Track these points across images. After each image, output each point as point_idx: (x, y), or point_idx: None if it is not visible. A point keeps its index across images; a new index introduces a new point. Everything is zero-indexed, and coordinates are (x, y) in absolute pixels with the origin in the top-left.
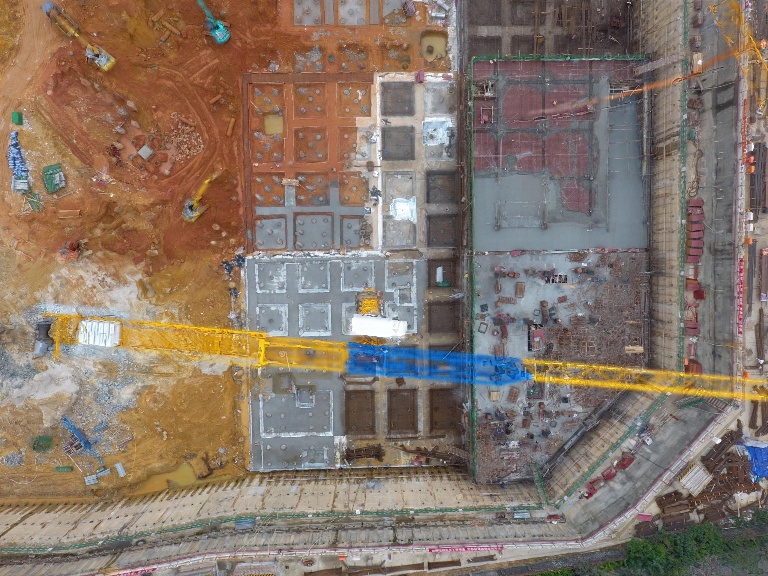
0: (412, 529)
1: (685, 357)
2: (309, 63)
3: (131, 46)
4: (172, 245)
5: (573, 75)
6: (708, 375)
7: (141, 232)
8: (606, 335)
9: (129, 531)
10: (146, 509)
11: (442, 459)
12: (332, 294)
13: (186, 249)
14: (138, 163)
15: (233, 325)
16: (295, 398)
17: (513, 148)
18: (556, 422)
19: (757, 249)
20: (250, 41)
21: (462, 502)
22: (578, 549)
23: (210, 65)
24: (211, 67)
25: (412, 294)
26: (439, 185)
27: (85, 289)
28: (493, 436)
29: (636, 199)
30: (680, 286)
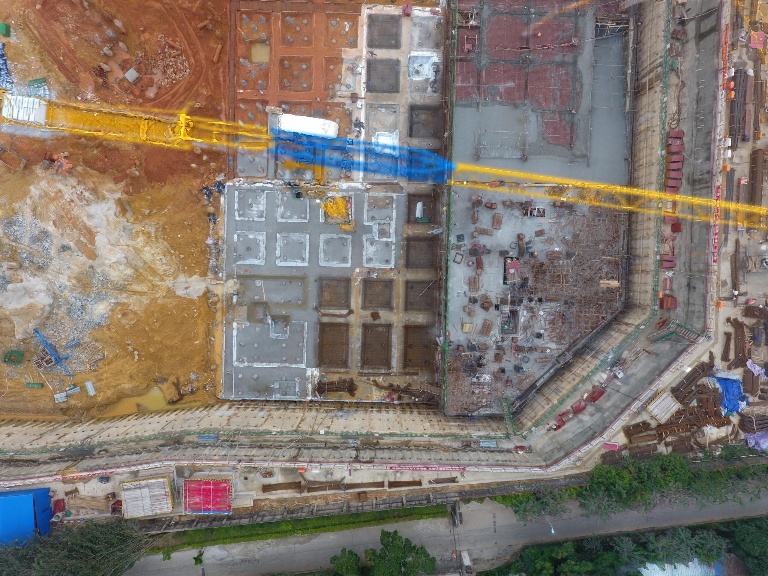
0: (375, 451)
1: (660, 291)
2: None
3: None
4: (153, 166)
5: (559, 8)
6: (682, 308)
7: (123, 152)
8: (583, 272)
9: (92, 440)
10: (112, 425)
11: (414, 397)
12: (311, 224)
13: (167, 172)
14: (124, 86)
15: (210, 251)
16: (269, 328)
17: (496, 78)
18: (529, 358)
19: (735, 178)
20: None
21: (428, 429)
22: (542, 476)
23: None
24: None
25: (391, 229)
26: (423, 120)
27: (63, 203)
28: (464, 368)
29: (618, 136)
30: (658, 218)
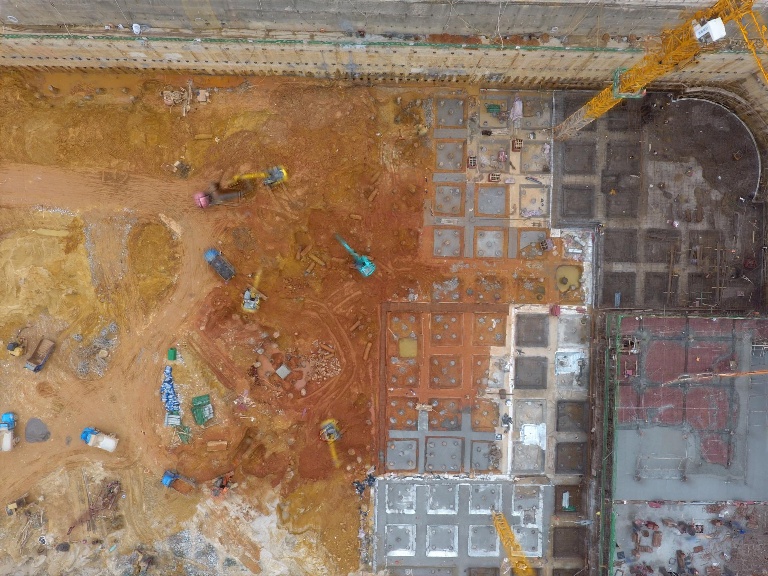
0: None
1: None
2: (446, 292)
3: (279, 279)
4: (309, 469)
5: (716, 332)
6: None
7: (279, 455)
8: None
9: None
10: None
11: None
12: (460, 516)
13: (320, 469)
14: (275, 381)
15: (361, 543)
16: None
17: (655, 401)
18: None
19: None
20: (391, 272)
21: None
22: None
23: (353, 296)
24: (354, 298)
25: (537, 516)
26: (568, 412)
27: (229, 520)
28: None
29: None
30: None
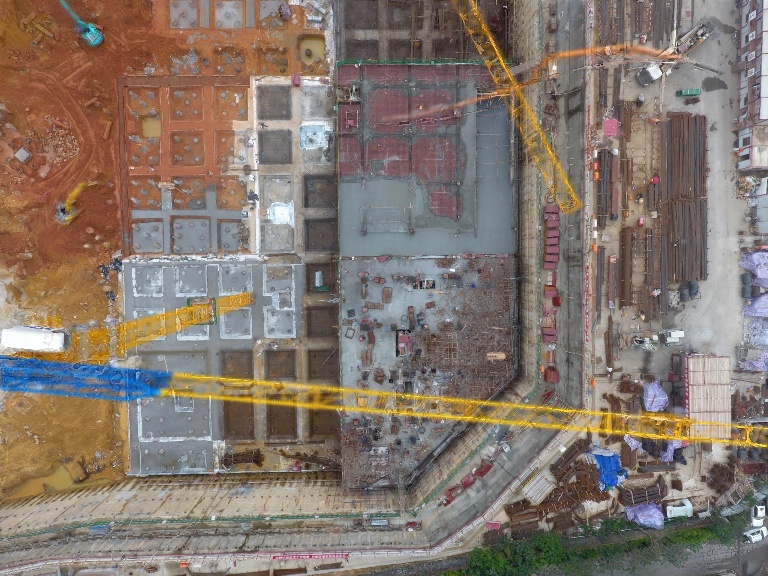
0: (265, 536)
1: (544, 364)
2: (186, 66)
3: (2, 48)
4: (45, 248)
5: (440, 80)
6: (563, 382)
7: (14, 235)
8: (475, 341)
9: None
10: (11, 513)
11: (322, 464)
12: None
13: (62, 252)
14: (15, 166)
15: (110, 329)
16: (174, 402)
17: (379, 153)
18: (425, 428)
19: (606, 256)
20: (125, 44)
21: (321, 509)
22: (426, 557)
23: (83, 68)
24: (84, 70)
25: (292, 298)
26: (318, 189)
27: None
28: (359, 442)
29: (505, 204)
30: (538, 293)
